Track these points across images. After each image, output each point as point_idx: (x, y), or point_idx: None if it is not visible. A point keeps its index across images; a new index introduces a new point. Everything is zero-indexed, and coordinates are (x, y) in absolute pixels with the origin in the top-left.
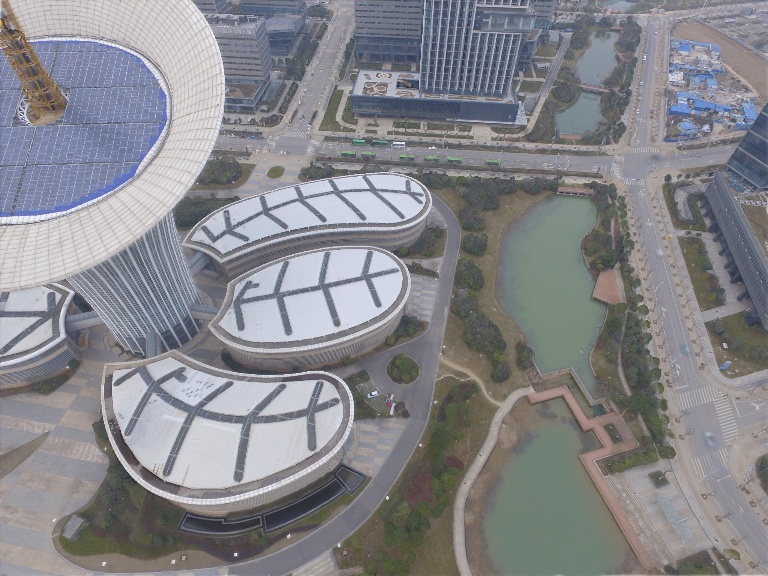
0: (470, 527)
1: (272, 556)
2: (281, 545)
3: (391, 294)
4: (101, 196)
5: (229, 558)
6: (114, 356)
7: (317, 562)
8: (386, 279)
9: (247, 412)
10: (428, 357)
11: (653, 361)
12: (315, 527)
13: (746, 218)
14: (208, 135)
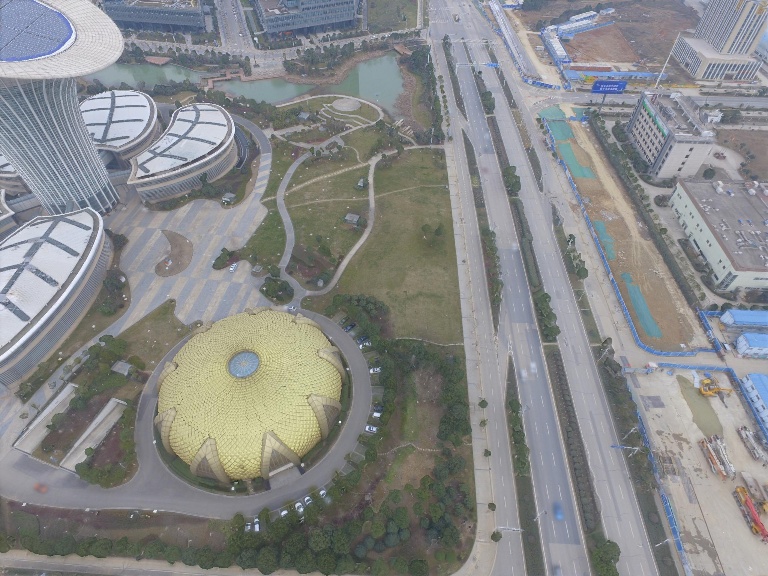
0: None
1: None
2: None
3: None
4: None
5: (258, 152)
6: (108, 218)
7: None
8: (118, 93)
9: None
10: (174, 107)
11: (207, 53)
12: None
13: (143, 6)
14: None
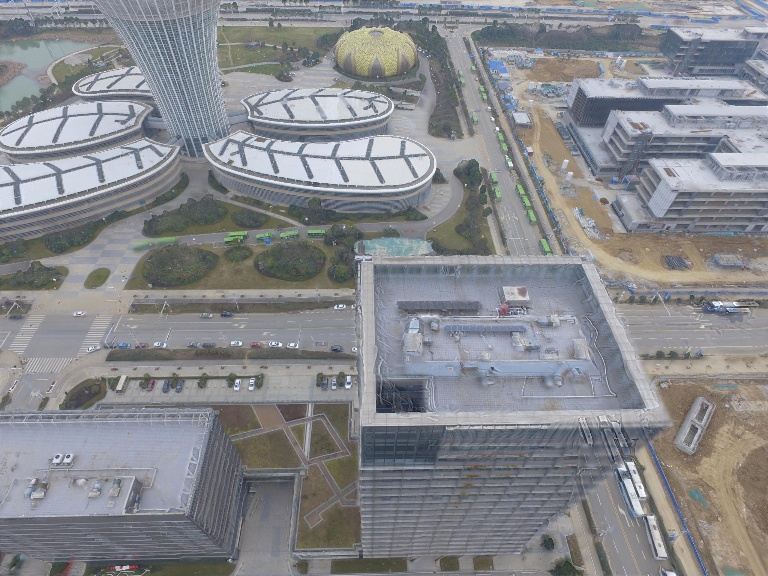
0: None
1: None
2: None
3: None
4: None
5: None
6: None
7: None
8: (16, 127)
9: None
10: None
11: None
12: None
13: None
14: None
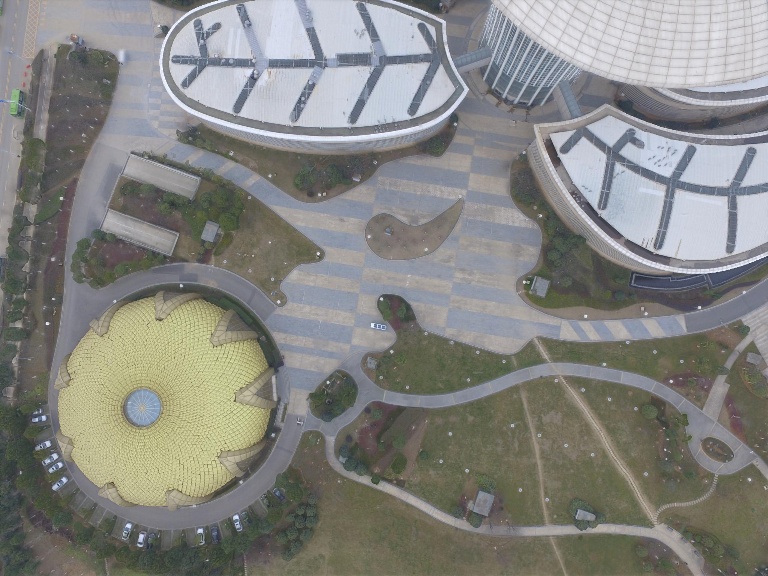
0: None
1: (721, 306)
2: (727, 297)
3: None
4: None
5: (685, 309)
6: (491, 107)
7: (762, 310)
8: None
9: (728, 183)
10: None
11: None
12: (756, 282)
13: None
14: None
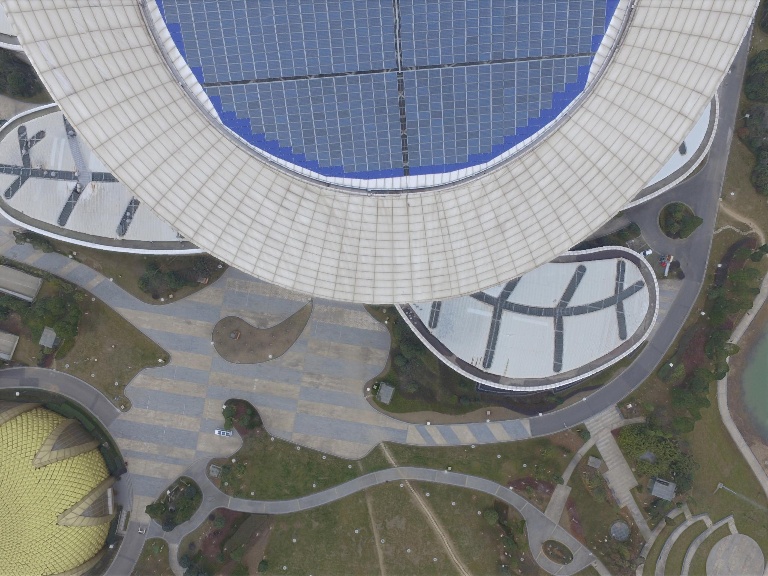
0: (731, 379)
1: (565, 410)
2: (571, 401)
3: (698, 133)
4: (536, 132)
5: (530, 413)
6: None
7: (605, 414)
8: None
9: (555, 303)
10: (706, 203)
11: None
12: (600, 386)
13: None
14: (745, 3)
